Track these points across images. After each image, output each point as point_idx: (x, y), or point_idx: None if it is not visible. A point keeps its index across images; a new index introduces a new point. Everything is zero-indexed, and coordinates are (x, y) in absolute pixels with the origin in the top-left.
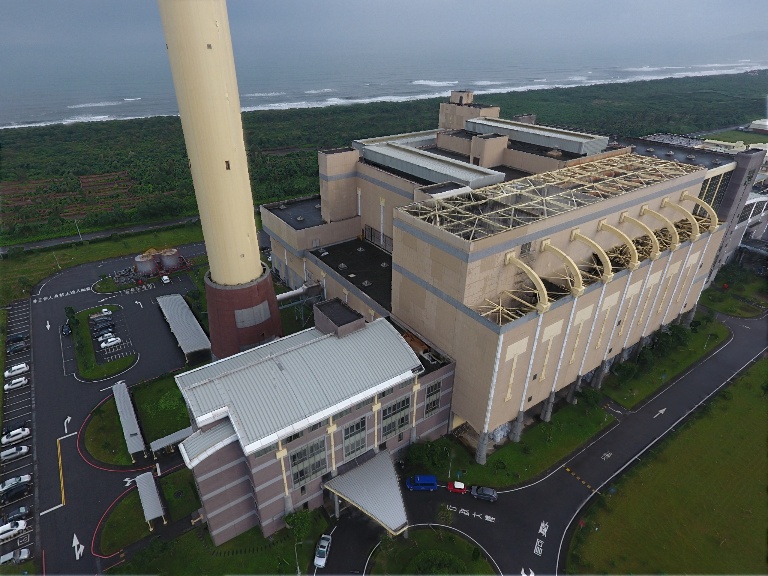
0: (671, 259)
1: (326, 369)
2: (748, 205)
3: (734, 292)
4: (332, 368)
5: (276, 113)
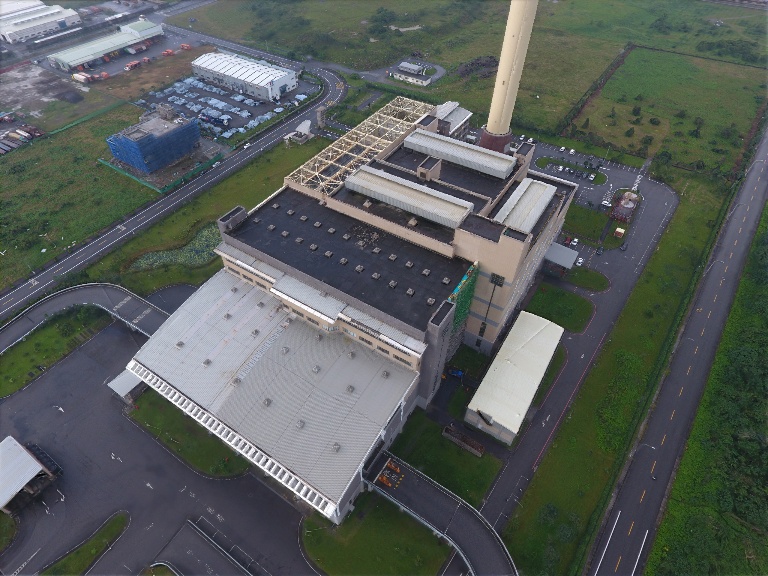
0: None
1: None
2: None
3: None
4: None
5: None
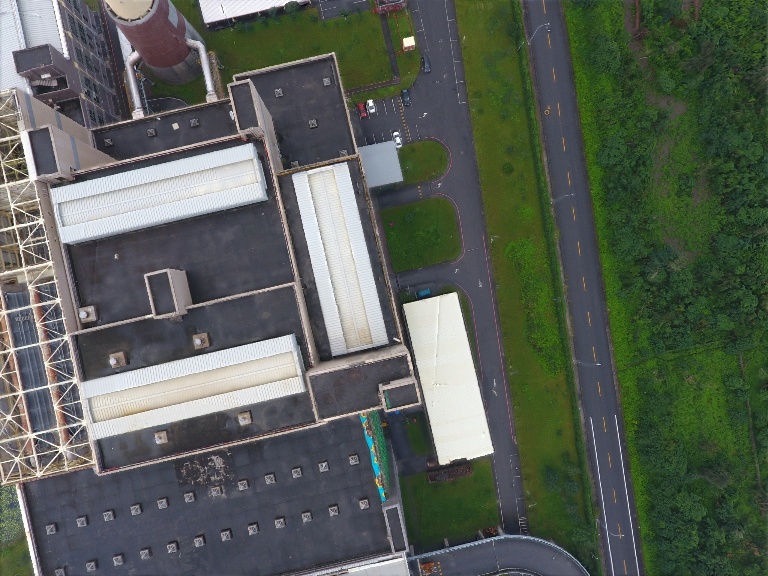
0: None
1: None
2: None
3: None
4: None
5: None
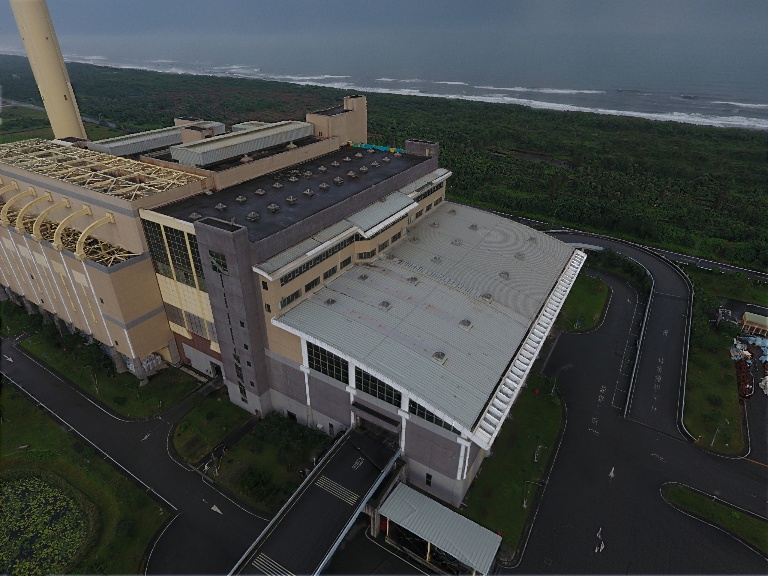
0: (46, 251)
1: None
2: (322, 348)
3: (243, 438)
4: None
5: (623, 121)
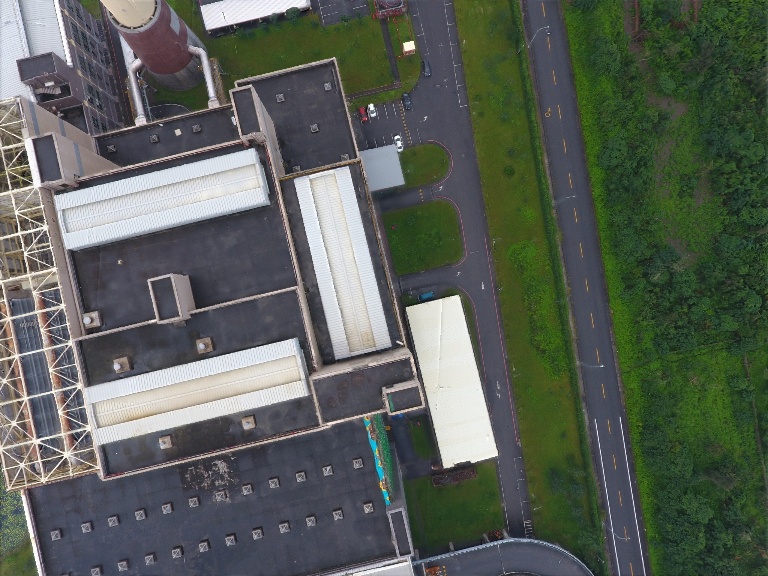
0: None
1: (1, 51)
2: None
3: None
4: (1, 55)
5: None
